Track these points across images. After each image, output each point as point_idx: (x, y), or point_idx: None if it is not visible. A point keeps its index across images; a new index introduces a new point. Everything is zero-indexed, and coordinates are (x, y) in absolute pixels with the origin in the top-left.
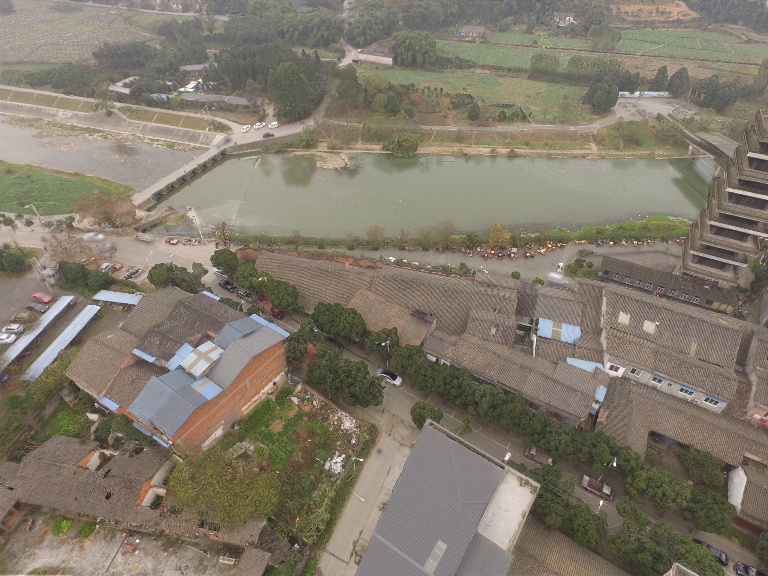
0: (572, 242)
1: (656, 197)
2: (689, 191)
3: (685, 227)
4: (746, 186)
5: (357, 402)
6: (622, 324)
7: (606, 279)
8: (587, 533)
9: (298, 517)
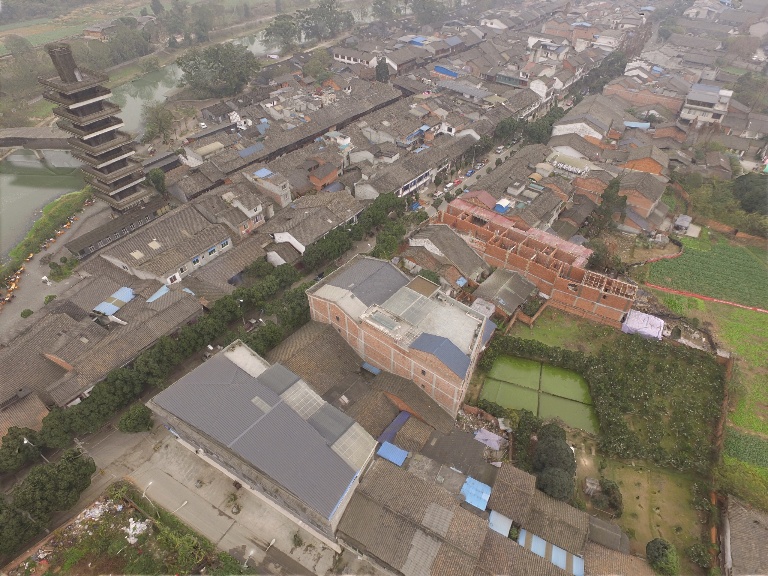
0: (24, 263)
1: (25, 197)
2: (39, 178)
3: (75, 198)
4: (91, 130)
5: (78, 491)
6: (141, 258)
7: (87, 257)
8: (276, 332)
9: (173, 575)
